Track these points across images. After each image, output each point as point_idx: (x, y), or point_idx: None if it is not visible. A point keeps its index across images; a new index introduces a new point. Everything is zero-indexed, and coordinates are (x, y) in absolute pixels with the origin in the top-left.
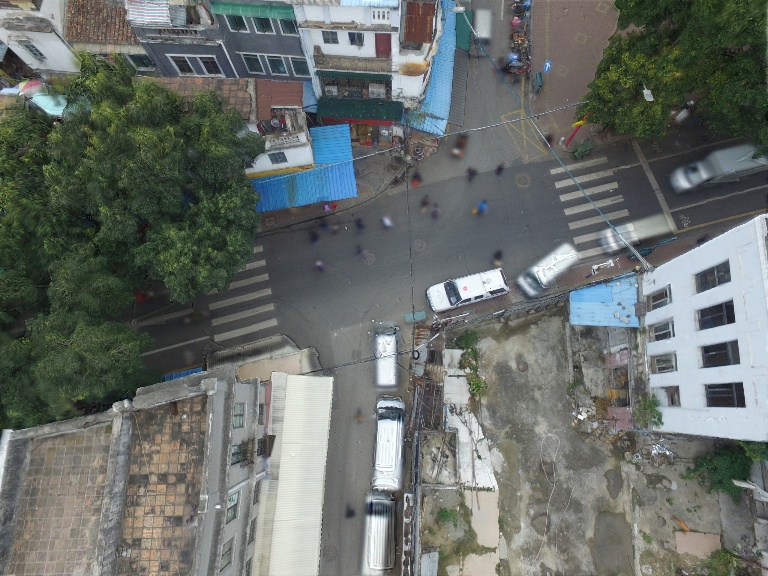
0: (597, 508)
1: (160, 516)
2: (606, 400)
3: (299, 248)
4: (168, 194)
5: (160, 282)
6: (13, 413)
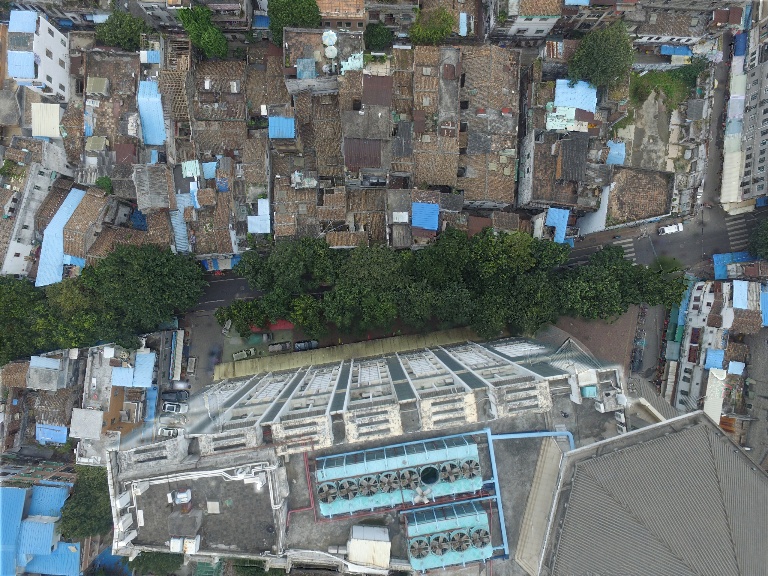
0: None
1: None
2: None
3: (720, 248)
4: None
5: None
6: None
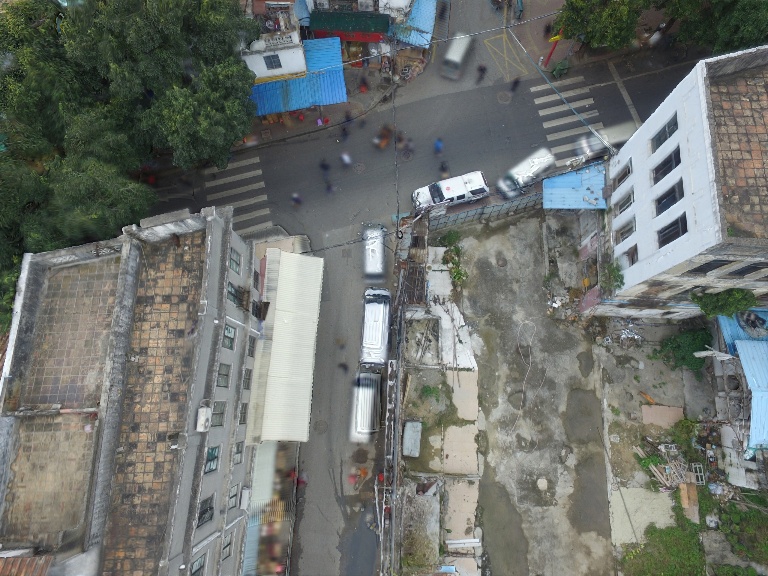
0: (569, 386)
1: (164, 329)
2: (579, 290)
3: (293, 159)
4: (171, 62)
5: (164, 161)
6: (34, 235)
